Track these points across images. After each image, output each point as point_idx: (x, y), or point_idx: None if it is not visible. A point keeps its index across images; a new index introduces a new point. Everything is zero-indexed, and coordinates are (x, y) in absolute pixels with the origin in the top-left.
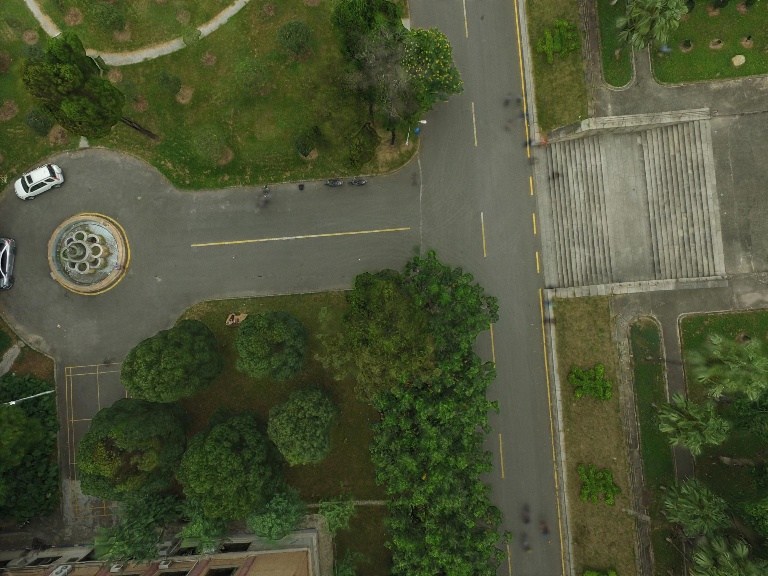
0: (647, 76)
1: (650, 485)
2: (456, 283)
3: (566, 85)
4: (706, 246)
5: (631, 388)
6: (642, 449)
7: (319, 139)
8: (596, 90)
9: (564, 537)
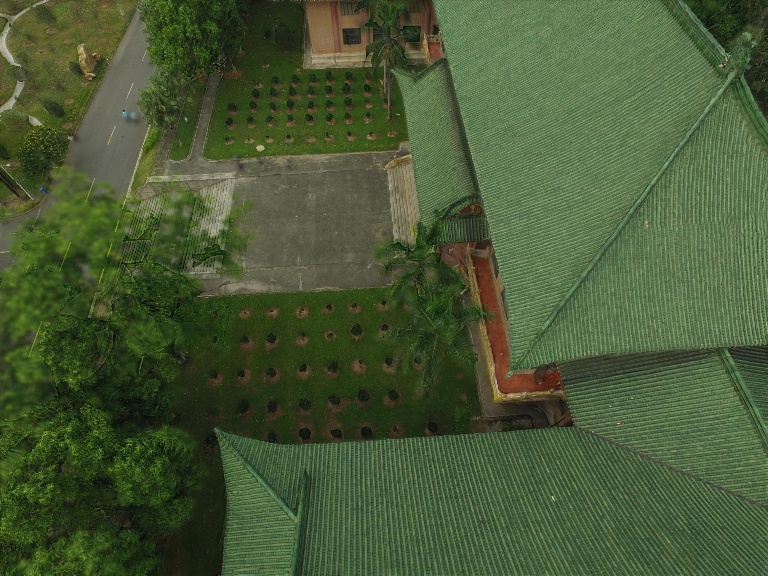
0: (198, 156)
1: None
2: None
3: (148, 163)
4: None
5: None
6: None
7: None
8: (161, 162)
9: None
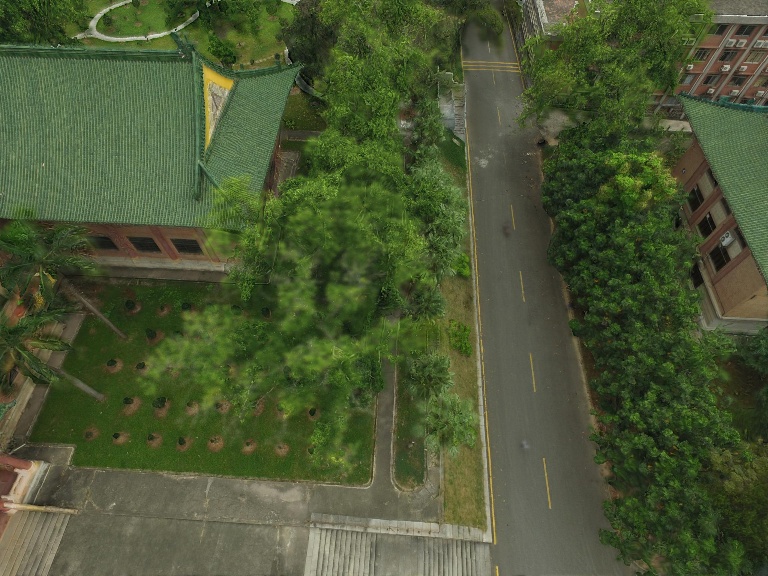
0: None
1: (422, 331)
2: None
3: None
4: (323, 569)
5: None
6: None
7: None
8: None
9: (477, 302)
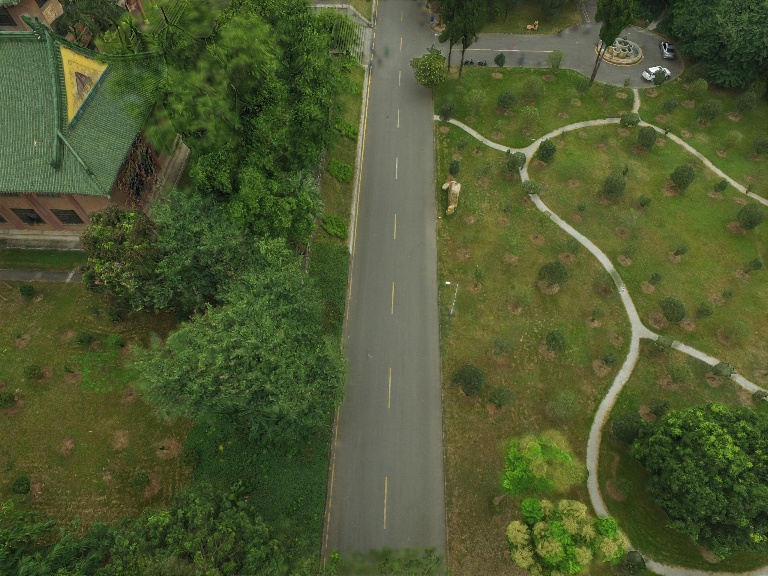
0: None
1: None
2: None
3: None
4: None
5: None
6: None
7: (491, 79)
8: None
9: None
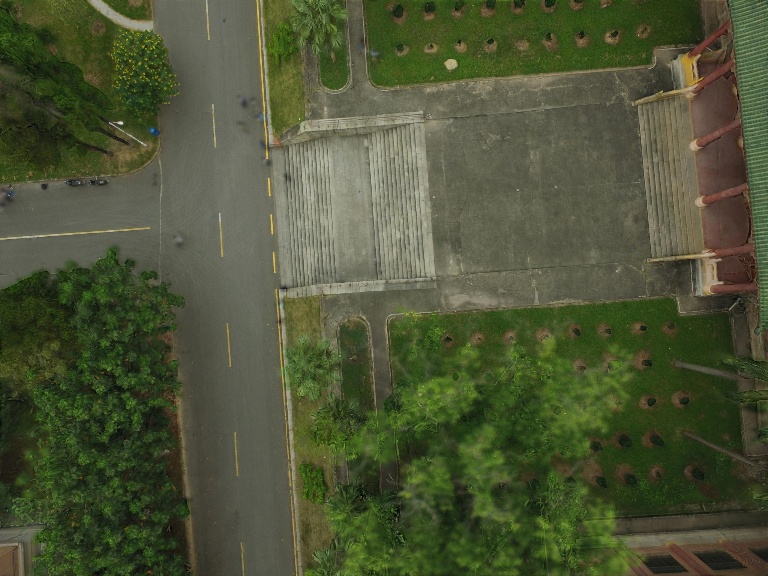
0: (363, 79)
1: None
2: (99, 282)
3: (290, 88)
4: (418, 248)
5: (339, 388)
6: (348, 448)
7: None
8: (313, 93)
9: None
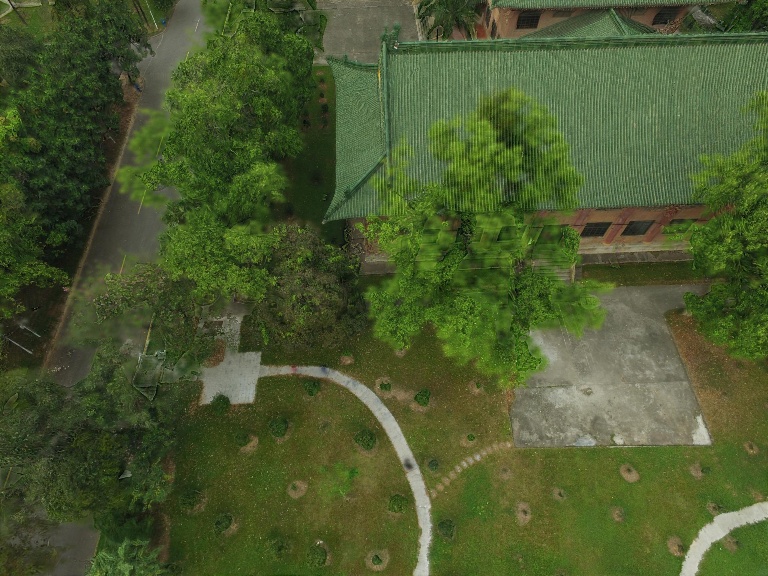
0: None
1: None
2: None
3: None
4: None
5: None
6: None
7: None
8: (251, 2)
9: None
